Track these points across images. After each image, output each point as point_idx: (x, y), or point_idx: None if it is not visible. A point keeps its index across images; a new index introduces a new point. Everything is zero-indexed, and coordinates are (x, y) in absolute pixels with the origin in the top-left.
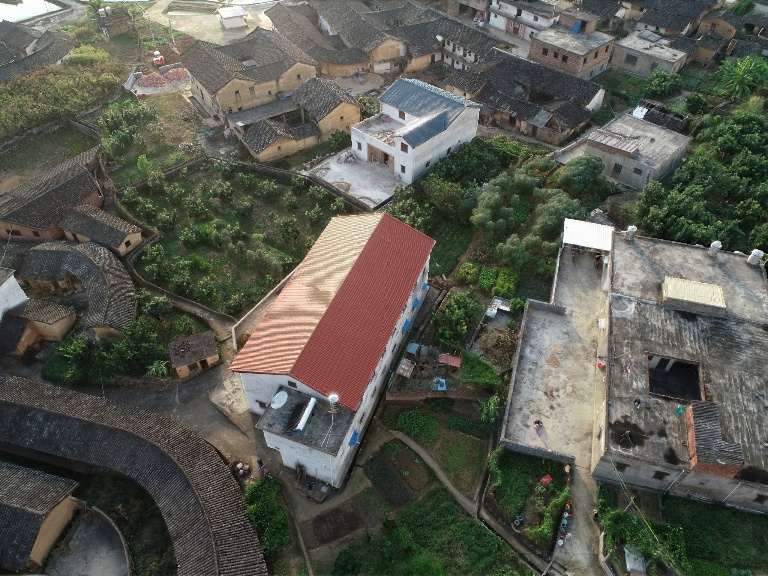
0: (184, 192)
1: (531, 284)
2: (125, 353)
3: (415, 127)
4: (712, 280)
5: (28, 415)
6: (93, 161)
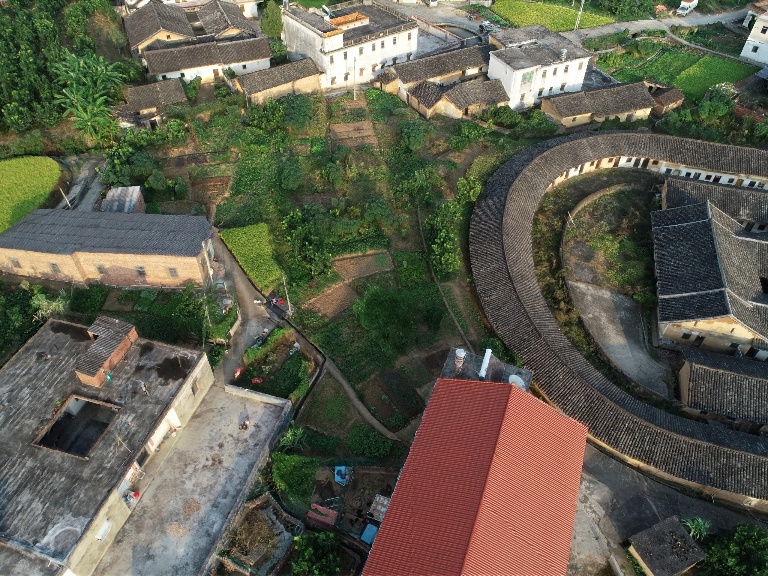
0: None
1: None
2: None
3: None
4: None
5: None
6: None
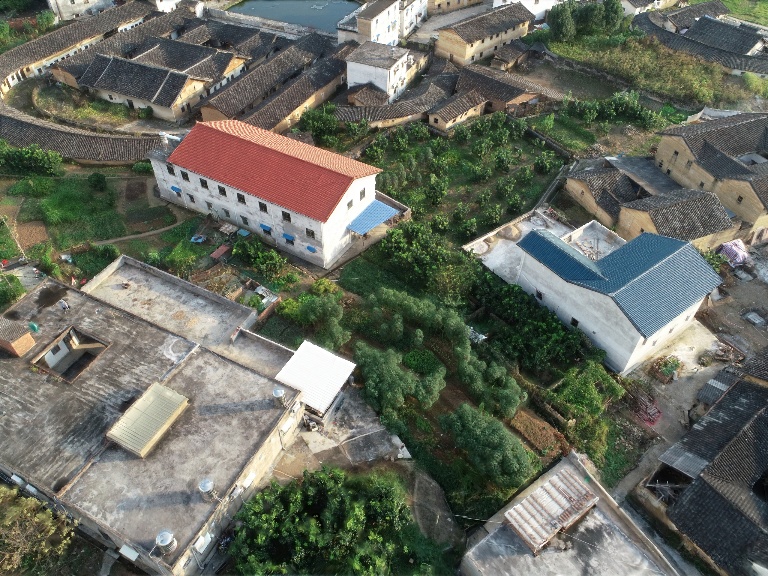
0: None
1: (288, 334)
2: None
3: (554, 243)
4: (167, 467)
5: (279, 94)
6: None
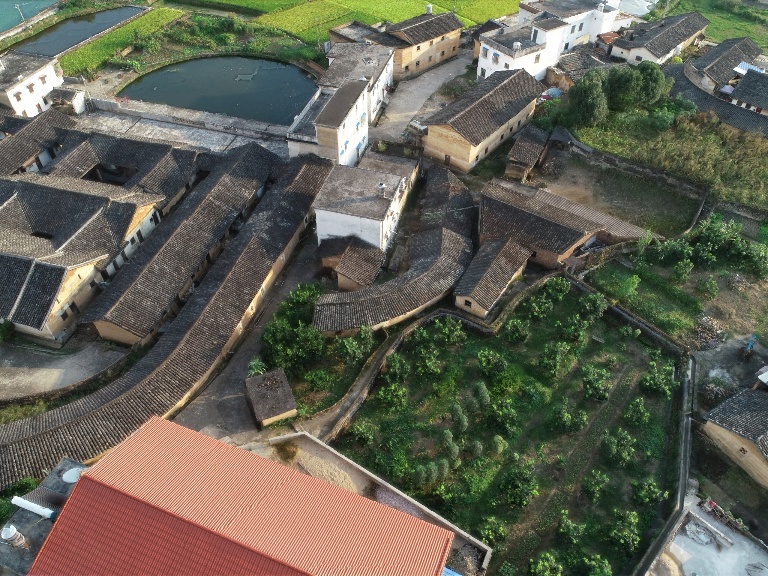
0: (600, 343)
1: None
2: (269, 332)
3: None
4: None
5: (218, 282)
6: (621, 238)
